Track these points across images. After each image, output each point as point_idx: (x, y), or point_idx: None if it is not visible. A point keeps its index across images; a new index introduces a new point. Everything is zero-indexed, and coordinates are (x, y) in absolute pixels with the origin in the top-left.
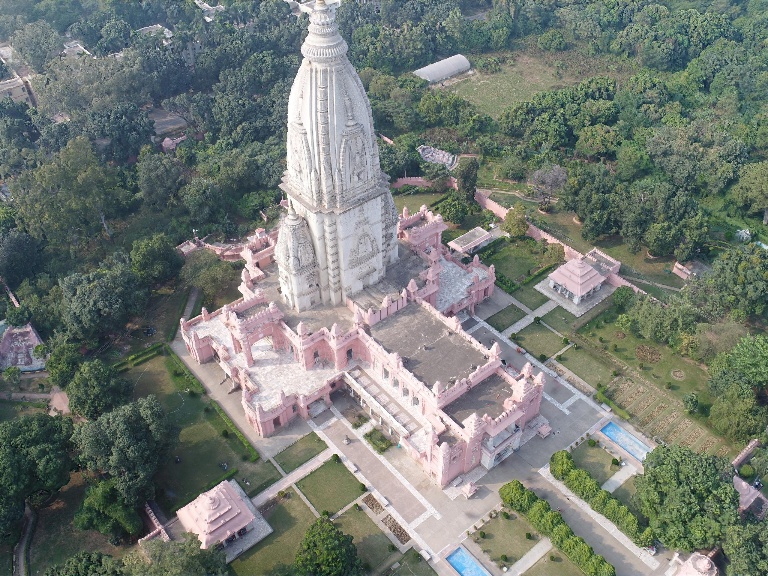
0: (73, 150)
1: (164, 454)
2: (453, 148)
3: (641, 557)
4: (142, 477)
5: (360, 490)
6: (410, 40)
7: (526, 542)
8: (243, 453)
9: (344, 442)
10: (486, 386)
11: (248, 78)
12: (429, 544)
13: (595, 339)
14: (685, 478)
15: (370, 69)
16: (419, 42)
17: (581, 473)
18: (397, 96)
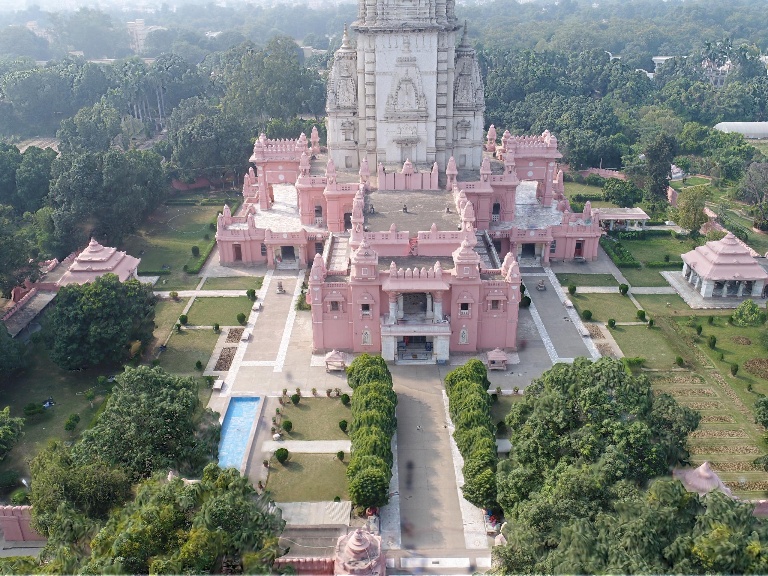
0: (273, 40)
1: (111, 213)
2: (687, 164)
3: (467, 525)
4: (74, 212)
5: (238, 320)
6: (727, 97)
7: (336, 432)
8: (191, 267)
9: (277, 290)
10: (438, 260)
11: (510, 82)
12: (236, 381)
13: (693, 330)
14: (574, 390)
15: (654, 105)
16: (736, 98)
17: (471, 384)
18: (662, 123)
